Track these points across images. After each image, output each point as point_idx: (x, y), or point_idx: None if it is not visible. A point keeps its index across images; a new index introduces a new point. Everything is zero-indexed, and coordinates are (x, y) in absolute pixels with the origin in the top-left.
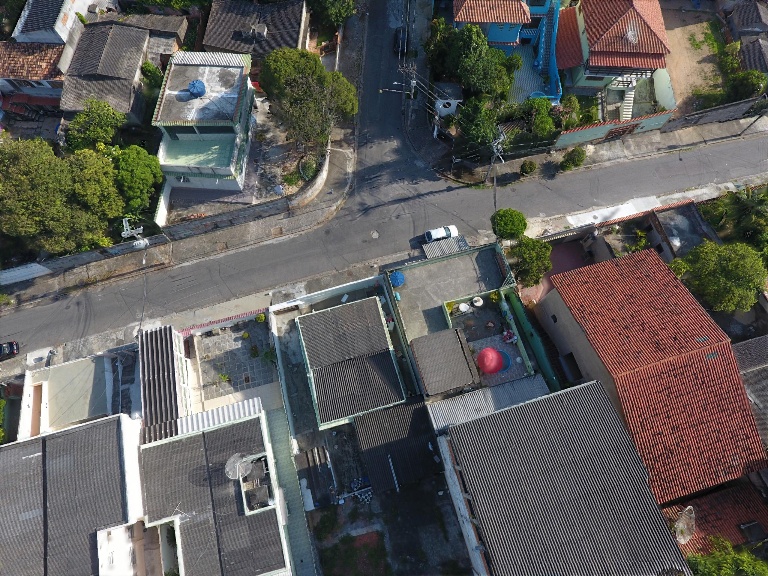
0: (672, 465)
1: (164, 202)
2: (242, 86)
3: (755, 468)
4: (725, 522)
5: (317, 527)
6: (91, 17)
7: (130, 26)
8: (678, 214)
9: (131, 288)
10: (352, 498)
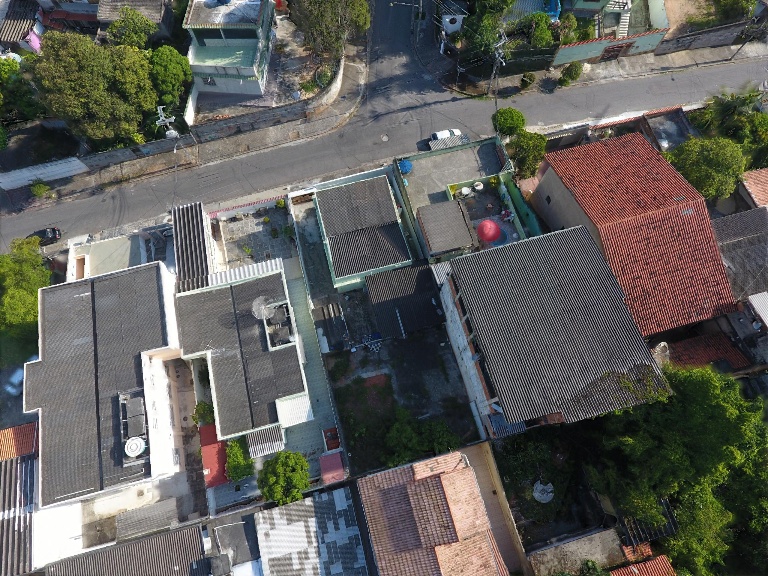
0: (649, 305)
1: (192, 104)
2: None
3: (724, 311)
4: (697, 360)
5: (332, 370)
6: None
7: None
8: (667, 120)
9: (161, 184)
10: (363, 347)
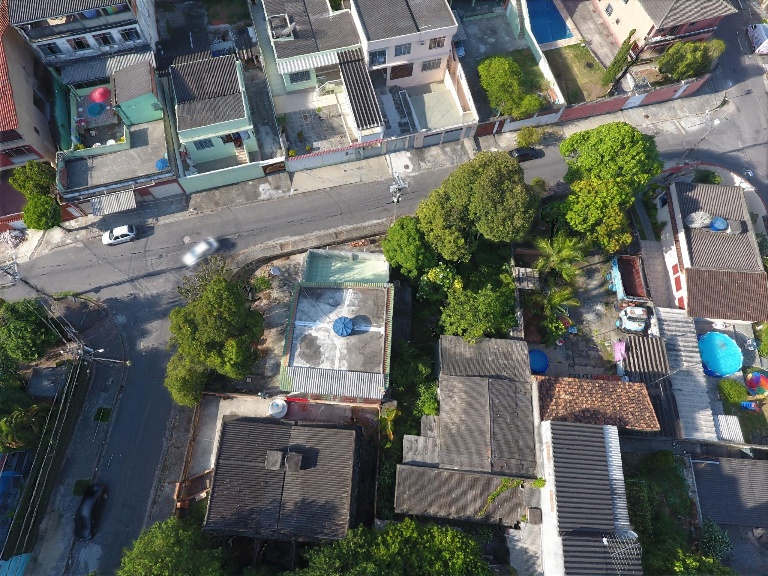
0: None
1: None
2: (290, 336)
3: None
4: None
5: None
6: (533, 499)
7: (467, 471)
8: None
9: None
10: None
